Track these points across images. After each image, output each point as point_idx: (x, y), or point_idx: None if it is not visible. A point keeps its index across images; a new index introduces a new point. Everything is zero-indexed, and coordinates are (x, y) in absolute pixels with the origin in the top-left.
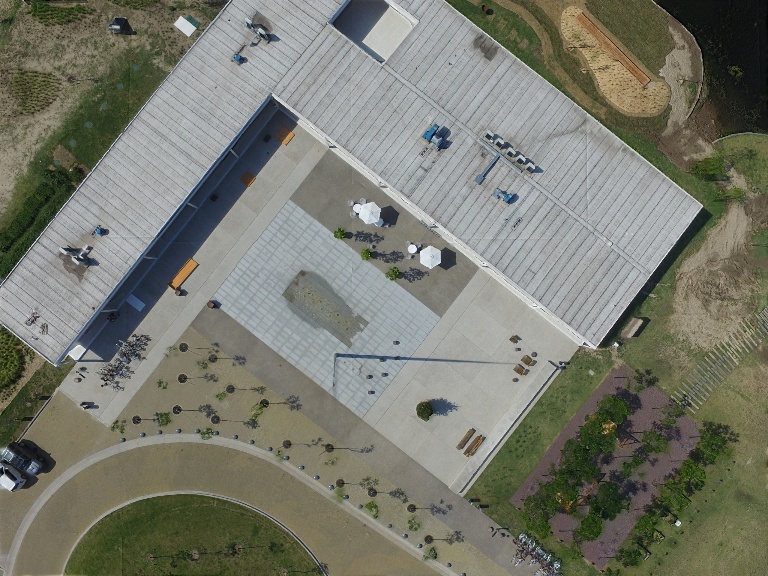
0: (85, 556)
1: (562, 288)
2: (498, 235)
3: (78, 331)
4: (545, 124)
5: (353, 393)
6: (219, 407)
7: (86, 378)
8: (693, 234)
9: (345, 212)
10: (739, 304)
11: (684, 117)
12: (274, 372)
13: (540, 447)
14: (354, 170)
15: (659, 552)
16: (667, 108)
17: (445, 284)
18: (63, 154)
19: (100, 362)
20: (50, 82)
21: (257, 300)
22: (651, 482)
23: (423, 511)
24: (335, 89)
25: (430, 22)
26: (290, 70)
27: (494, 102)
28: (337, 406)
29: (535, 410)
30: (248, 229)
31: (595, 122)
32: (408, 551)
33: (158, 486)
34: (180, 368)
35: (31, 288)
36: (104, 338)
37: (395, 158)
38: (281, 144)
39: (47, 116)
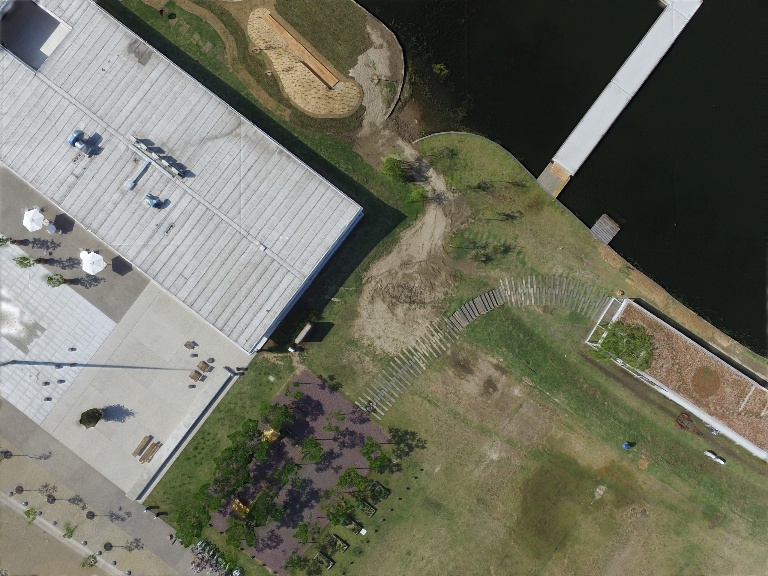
0: None
1: (215, 293)
2: (149, 241)
3: None
4: (198, 128)
5: (31, 400)
6: None
7: None
8: (380, 236)
9: (22, 219)
10: (428, 308)
11: (382, 117)
12: None
13: None
14: None
15: (344, 561)
16: (359, 109)
17: (121, 290)
18: None
19: None
20: None
21: None
22: (334, 490)
23: (102, 518)
24: None
25: (84, 28)
26: None
27: (147, 107)
28: (15, 413)
29: (213, 417)
30: None
31: (250, 125)
32: None
33: None
34: None
35: None
36: None
37: (47, 165)
38: None
39: None
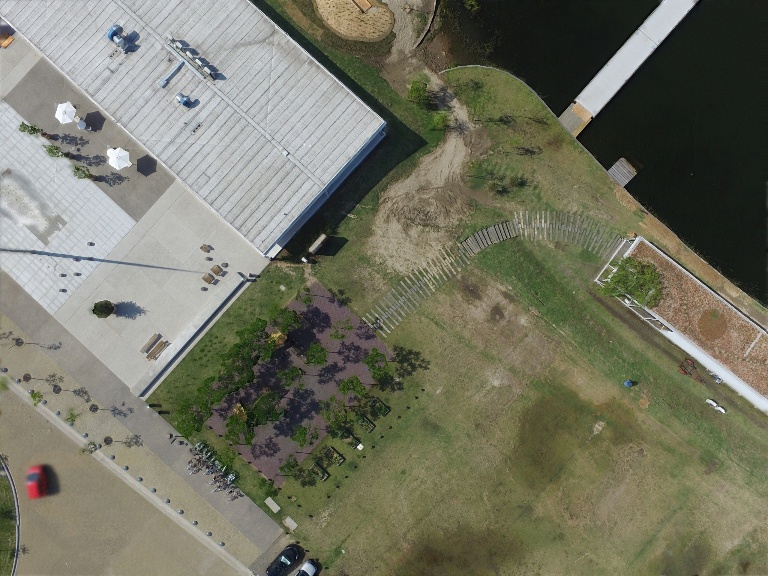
0: None
1: (235, 194)
2: (176, 138)
3: None
4: (233, 33)
5: (46, 290)
6: None
7: None
8: (400, 159)
9: (54, 115)
10: (442, 231)
11: (411, 46)
12: None
13: None
14: None
15: (339, 475)
16: (390, 35)
17: (144, 190)
18: None
19: None
20: None
21: None
22: None
23: (105, 412)
24: None
25: None
26: None
27: (185, 10)
28: (30, 302)
29: (222, 320)
30: None
31: (283, 34)
32: None
33: None
34: None
35: None
36: None
37: (84, 58)
38: (1, 47)
39: None
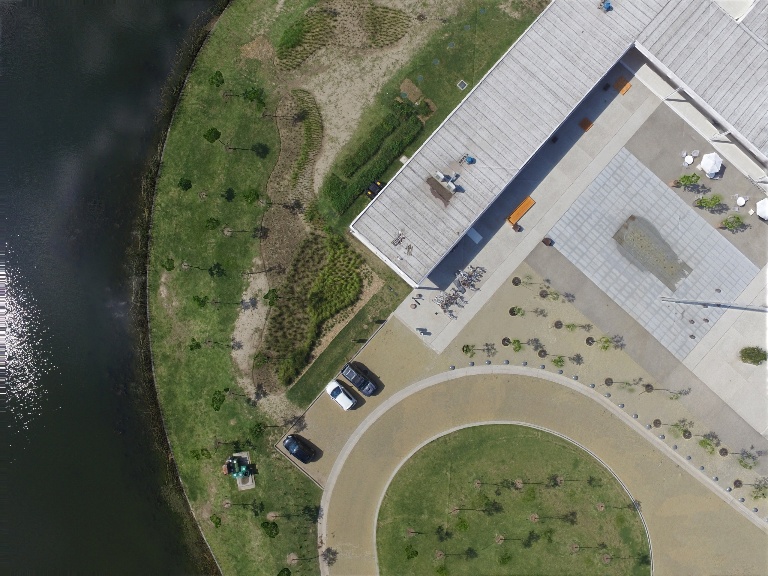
0: (412, 479)
1: None
2: None
3: (442, 254)
4: None
5: (675, 336)
6: (547, 342)
7: (421, 305)
8: None
9: (676, 162)
10: None
11: None
12: (601, 311)
13: None
14: (685, 123)
15: None
16: None
17: (766, 238)
18: (410, 88)
19: (436, 290)
20: (400, 18)
21: (589, 241)
22: None
23: (734, 455)
24: (694, 42)
25: None
26: (653, 21)
27: None
28: (659, 348)
29: None
30: (584, 172)
31: None
32: (717, 494)
33: (484, 415)
34: (512, 301)
35: (398, 210)
36: (441, 267)
37: (747, 111)
38: (618, 94)
39: (395, 51)
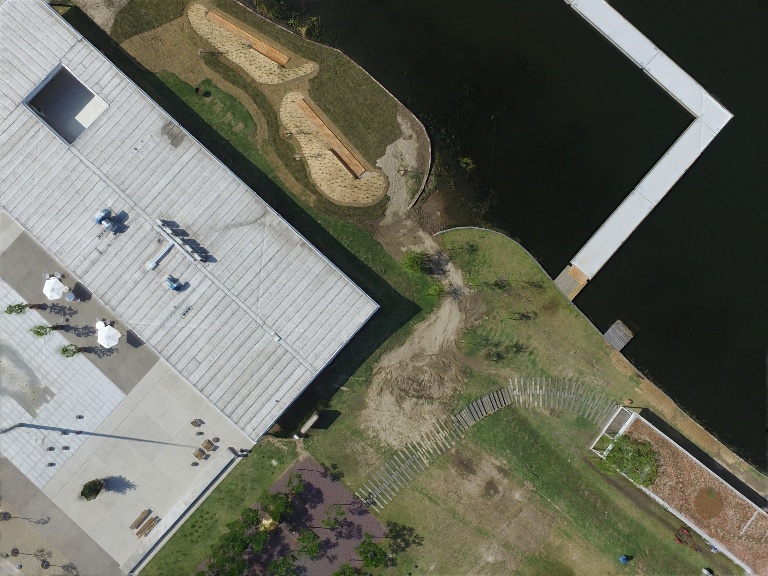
0: None
1: (226, 380)
2: (166, 322)
3: None
4: (224, 214)
5: (34, 464)
6: None
7: None
8: (394, 329)
9: (42, 284)
10: (436, 404)
11: (405, 207)
12: None
13: (217, 534)
14: None
15: None
16: (384, 198)
17: (133, 362)
18: None
19: None
20: None
21: None
22: None
23: None
24: (21, 167)
25: (120, 107)
26: None
27: (175, 189)
28: (18, 475)
29: (213, 496)
30: None
31: (275, 215)
32: None
33: None
34: None
35: None
36: None
37: (72, 239)
38: None
39: None
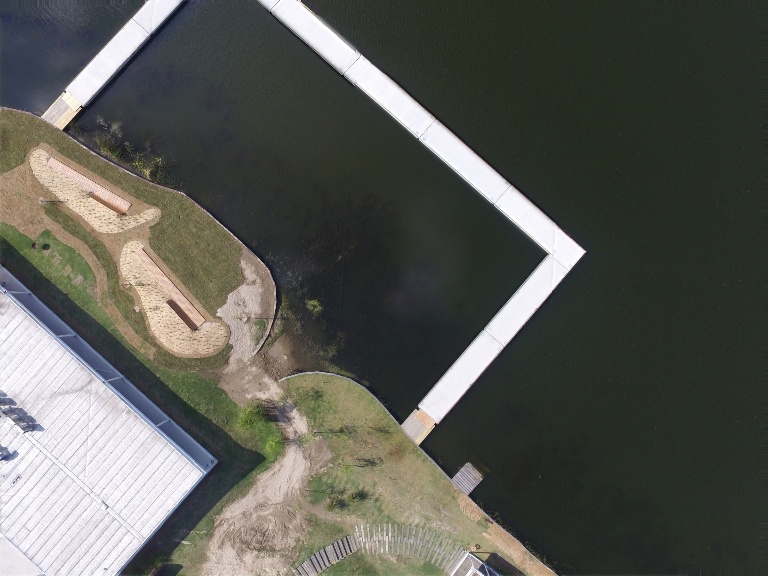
0: None
1: (55, 547)
2: None
3: None
4: (50, 382)
5: None
6: None
7: None
8: (235, 481)
9: None
10: (277, 556)
11: (250, 354)
12: None
13: None
14: None
15: None
16: (226, 347)
17: None
18: None
19: None
20: None
21: None
22: None
23: None
24: None
25: None
26: None
27: (2, 357)
28: None
29: None
30: None
31: (101, 382)
32: None
33: None
34: None
35: None
36: None
37: None
38: None
39: None
